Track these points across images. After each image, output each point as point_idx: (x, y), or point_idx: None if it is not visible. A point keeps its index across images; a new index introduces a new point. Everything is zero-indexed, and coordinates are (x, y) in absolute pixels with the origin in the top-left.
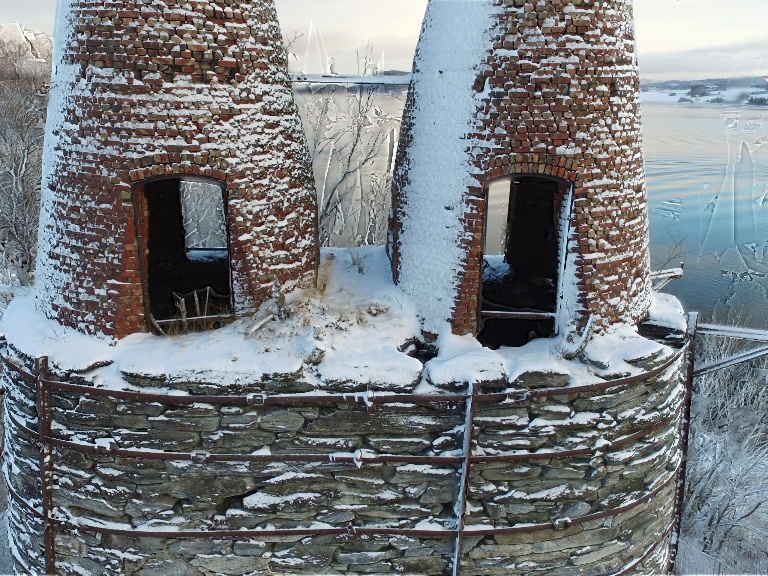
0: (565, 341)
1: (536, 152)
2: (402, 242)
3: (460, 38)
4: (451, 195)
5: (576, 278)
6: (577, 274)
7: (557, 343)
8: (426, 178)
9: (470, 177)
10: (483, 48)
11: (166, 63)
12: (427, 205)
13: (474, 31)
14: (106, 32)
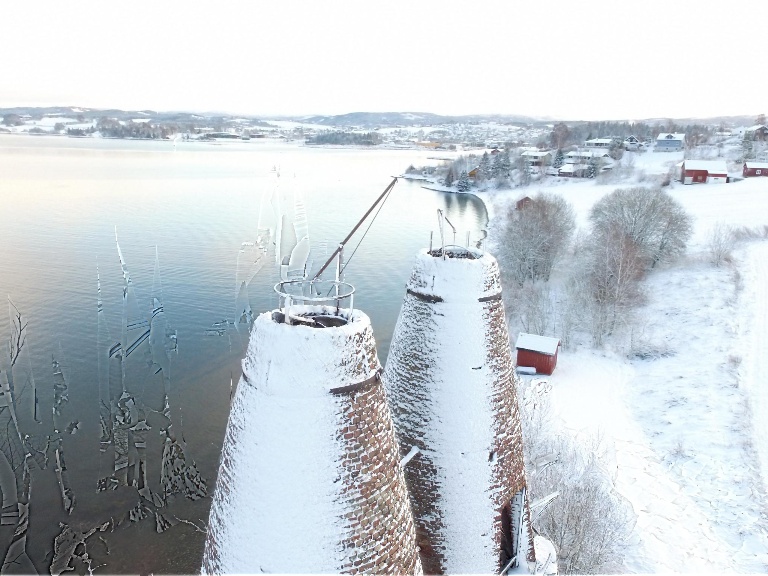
0: (537, 572)
1: (517, 481)
2: (447, 567)
3: (477, 433)
4: (486, 527)
5: (528, 533)
6: (528, 531)
7: (529, 574)
8: (464, 522)
9: (495, 512)
10: (492, 436)
11: (412, 567)
12: (468, 538)
13: (485, 428)
14: (384, 574)
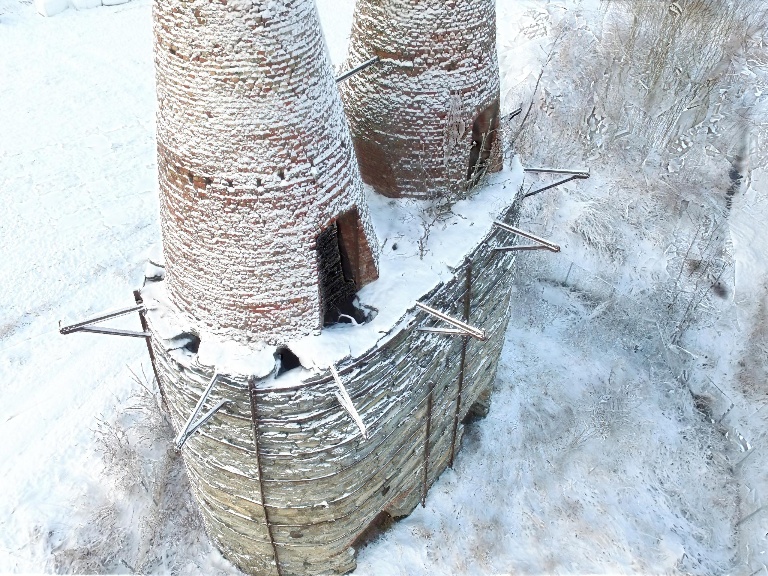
0: None
1: None
2: None
3: None
4: None
5: None
6: None
7: None
8: None
9: None
10: None
11: None
12: None
13: None
14: None
